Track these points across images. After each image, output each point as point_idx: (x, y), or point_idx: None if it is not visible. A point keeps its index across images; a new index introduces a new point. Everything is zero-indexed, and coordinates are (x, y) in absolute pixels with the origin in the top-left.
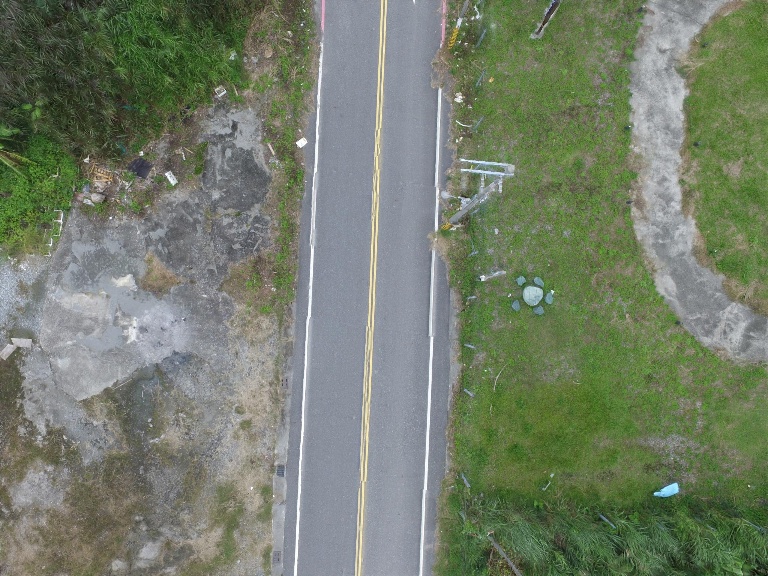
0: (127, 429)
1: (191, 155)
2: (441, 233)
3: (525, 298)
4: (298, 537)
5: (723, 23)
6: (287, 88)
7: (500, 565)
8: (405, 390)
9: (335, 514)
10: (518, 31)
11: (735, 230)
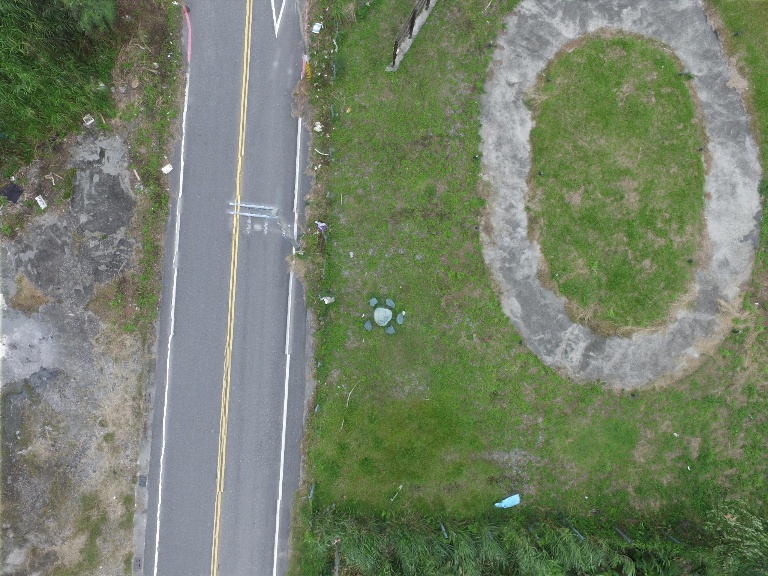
0: None
1: (60, 180)
2: (297, 256)
3: (375, 319)
4: (158, 544)
5: (568, 58)
6: (153, 117)
7: (345, 572)
8: (262, 405)
9: (193, 523)
10: (374, 64)
11: (576, 255)
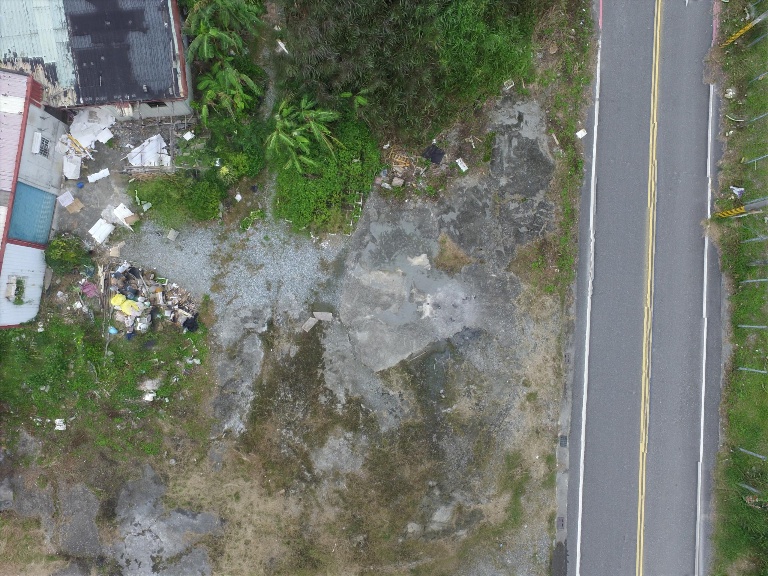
0: (421, 399)
1: (480, 143)
2: (716, 220)
3: None
4: (581, 504)
5: None
6: (570, 82)
7: None
8: (681, 368)
9: (617, 483)
10: None
11: None
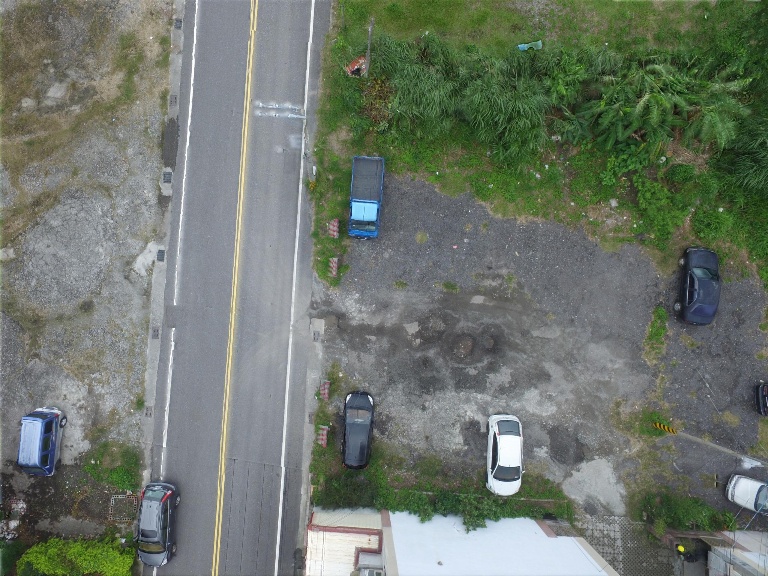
0: None
1: None
2: None
3: None
4: (193, 82)
5: None
6: None
7: (374, 96)
8: None
9: (227, 61)
10: None
11: None
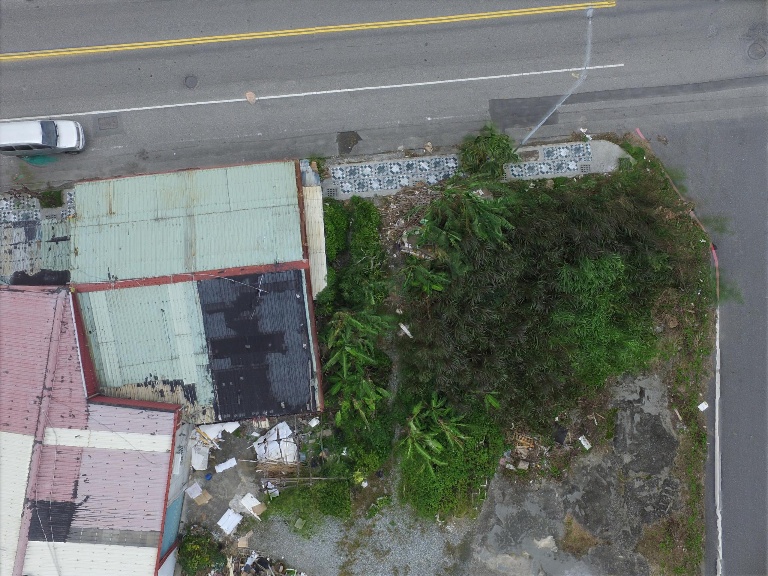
0: None
1: (602, 420)
2: None
3: None
4: None
5: None
6: (690, 356)
7: None
8: None
9: None
10: None
11: None
